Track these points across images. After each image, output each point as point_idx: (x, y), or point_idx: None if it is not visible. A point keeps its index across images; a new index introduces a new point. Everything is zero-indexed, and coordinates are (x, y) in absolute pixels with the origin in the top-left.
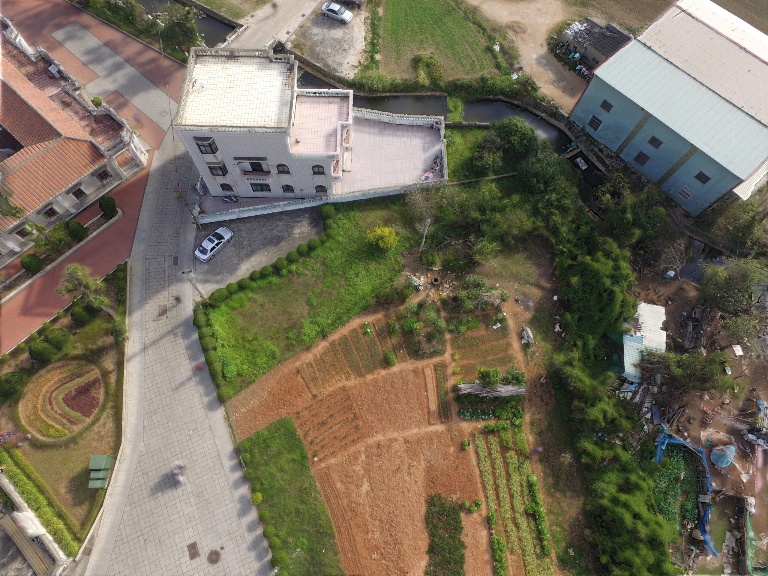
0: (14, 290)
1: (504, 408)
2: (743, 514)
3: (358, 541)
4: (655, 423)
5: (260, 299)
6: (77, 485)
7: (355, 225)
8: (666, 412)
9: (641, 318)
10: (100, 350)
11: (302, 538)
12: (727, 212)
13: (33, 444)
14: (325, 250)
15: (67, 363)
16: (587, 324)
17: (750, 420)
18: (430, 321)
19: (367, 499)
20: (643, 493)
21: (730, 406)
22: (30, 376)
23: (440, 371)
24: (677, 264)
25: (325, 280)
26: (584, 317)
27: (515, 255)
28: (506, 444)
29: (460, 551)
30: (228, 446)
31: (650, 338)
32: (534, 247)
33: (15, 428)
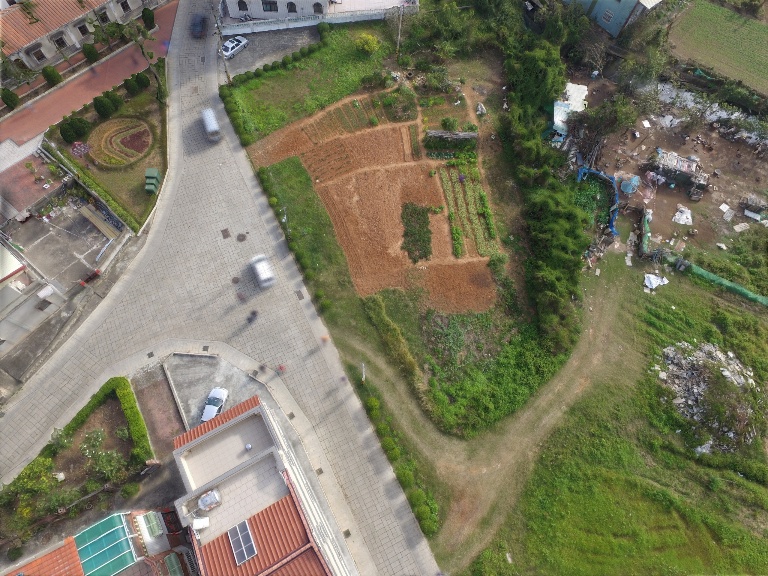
0: (77, 73)
1: (462, 152)
2: (642, 218)
3: (351, 229)
4: (579, 164)
5: (271, 84)
6: (135, 194)
7: (345, 38)
8: (587, 156)
9: (569, 92)
10: (147, 113)
11: (308, 227)
12: (639, 25)
13: (99, 168)
14: (322, 54)
15: (122, 120)
16: (528, 101)
17: (651, 161)
18: (405, 92)
19: (357, 205)
20: (565, 194)
21: (638, 157)
22: (94, 126)
23: (413, 129)
24: (599, 63)
25: (322, 73)
26: (525, 95)
27: (473, 61)
28: (463, 173)
29: (428, 235)
30: (250, 173)
31: (575, 105)
32: (488, 56)
33: (85, 158)
